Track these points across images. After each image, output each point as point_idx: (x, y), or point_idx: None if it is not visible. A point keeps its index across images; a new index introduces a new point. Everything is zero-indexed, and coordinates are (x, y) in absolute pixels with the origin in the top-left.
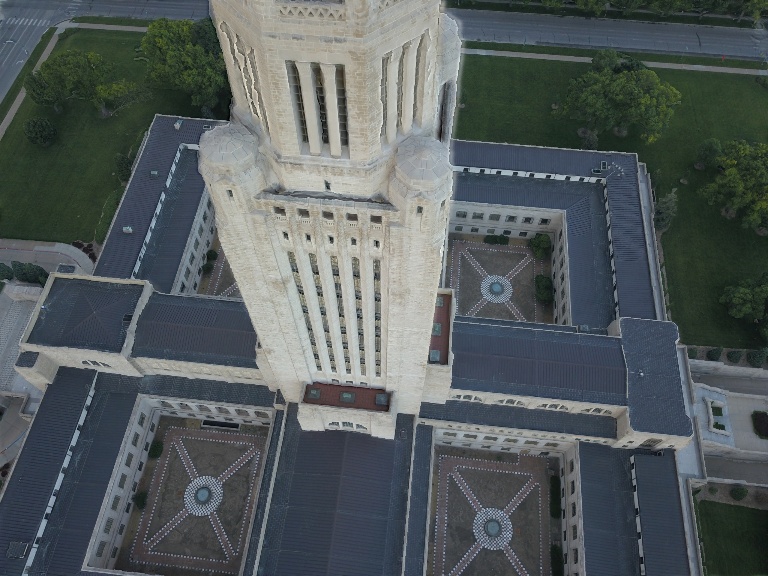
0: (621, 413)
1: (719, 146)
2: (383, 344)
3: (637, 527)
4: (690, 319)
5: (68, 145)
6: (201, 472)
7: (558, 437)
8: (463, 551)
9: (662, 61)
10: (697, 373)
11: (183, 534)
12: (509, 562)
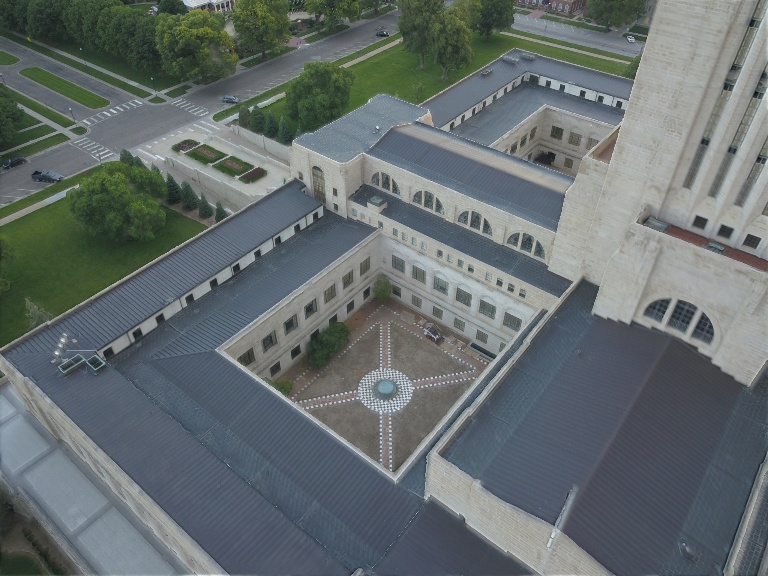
0: None
1: None
2: None
3: None
4: None
5: None
6: None
7: None
8: None
9: None
10: None
11: None
12: None
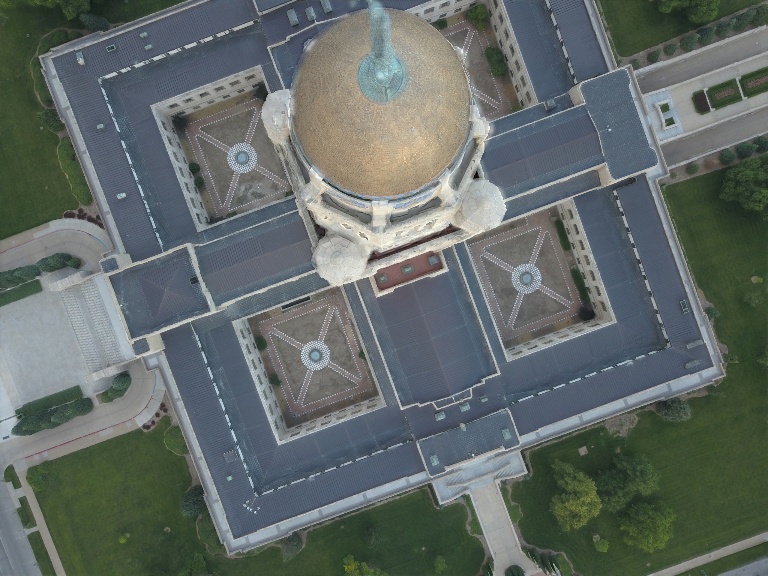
0: (601, 167)
1: None
2: None
3: (630, 240)
4: (627, 29)
5: None
6: (303, 342)
7: (557, 203)
8: (512, 303)
9: None
10: (641, 75)
11: (318, 385)
12: (546, 295)
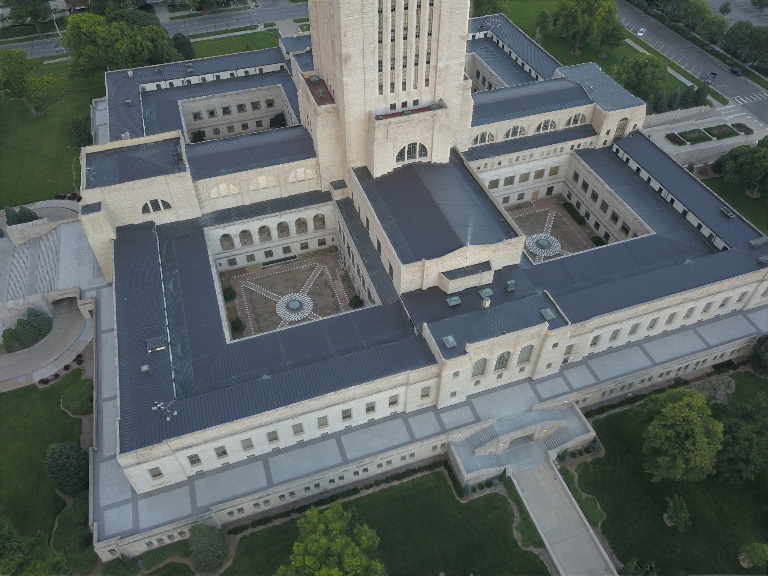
0: (592, 113)
1: (548, 13)
2: (435, 14)
3: (644, 178)
4: None
5: (8, 142)
6: (282, 294)
7: (558, 150)
8: None
9: None
10: None
11: None
12: None
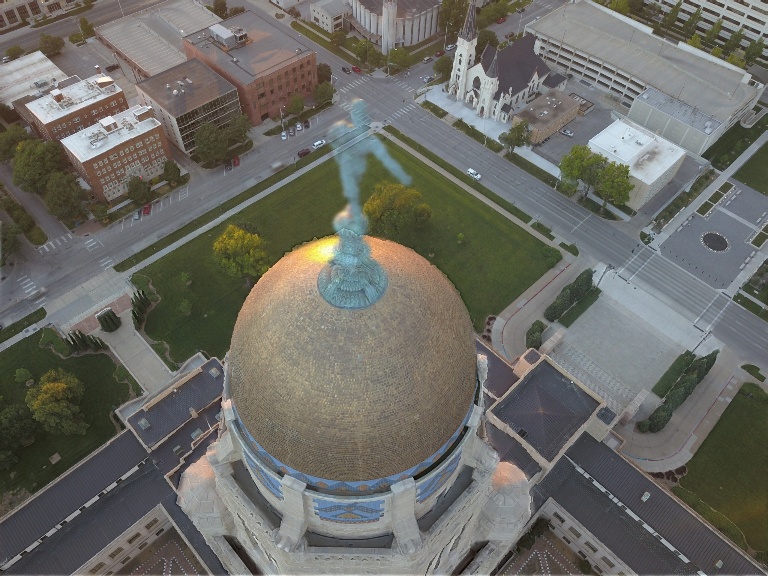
0: None
1: None
2: None
3: None
4: None
5: None
6: None
7: None
8: None
9: None
10: None
11: None
12: None
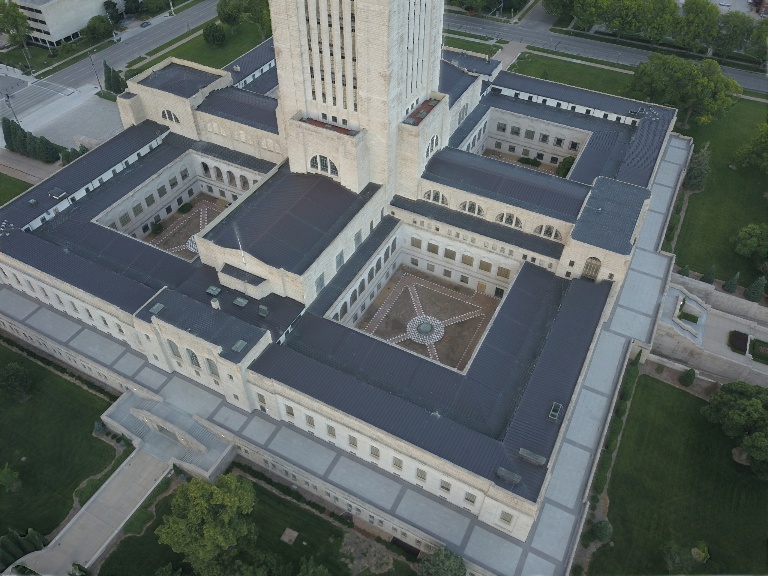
0: None
1: None
2: (356, 41)
3: None
4: (694, 253)
5: (229, 50)
6: None
7: (507, 251)
8: (391, 336)
9: (748, 95)
10: None
11: None
12: (428, 355)
